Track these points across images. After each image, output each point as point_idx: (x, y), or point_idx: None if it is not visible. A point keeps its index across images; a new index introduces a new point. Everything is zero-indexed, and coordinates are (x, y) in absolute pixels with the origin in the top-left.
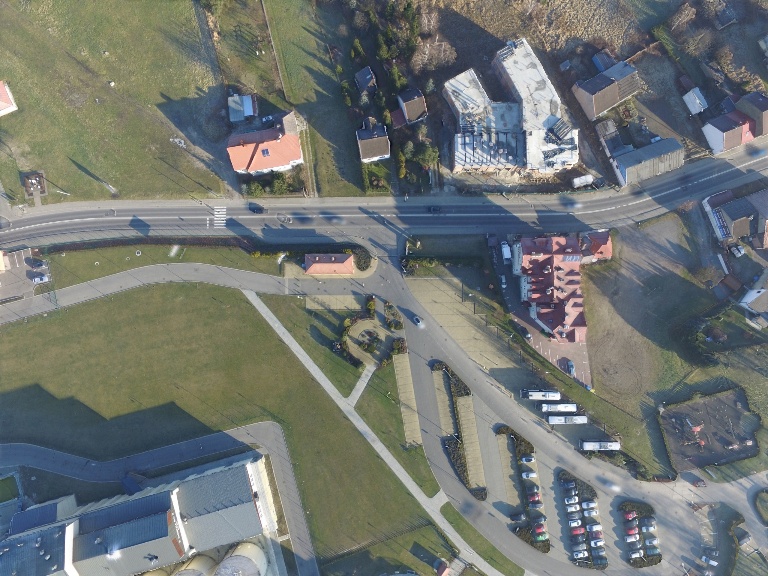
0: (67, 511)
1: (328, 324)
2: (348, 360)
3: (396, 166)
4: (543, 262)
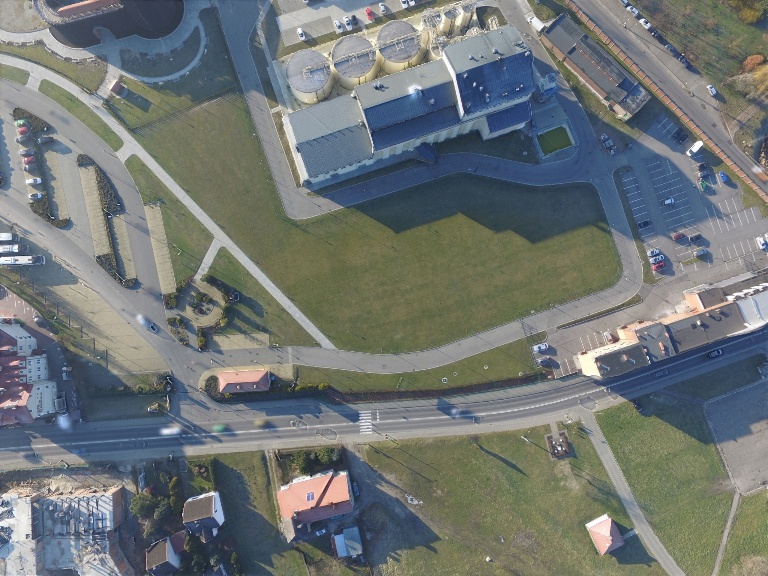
0: (481, 125)
1: (245, 319)
2: (220, 285)
3: (183, 489)
4: (7, 399)
